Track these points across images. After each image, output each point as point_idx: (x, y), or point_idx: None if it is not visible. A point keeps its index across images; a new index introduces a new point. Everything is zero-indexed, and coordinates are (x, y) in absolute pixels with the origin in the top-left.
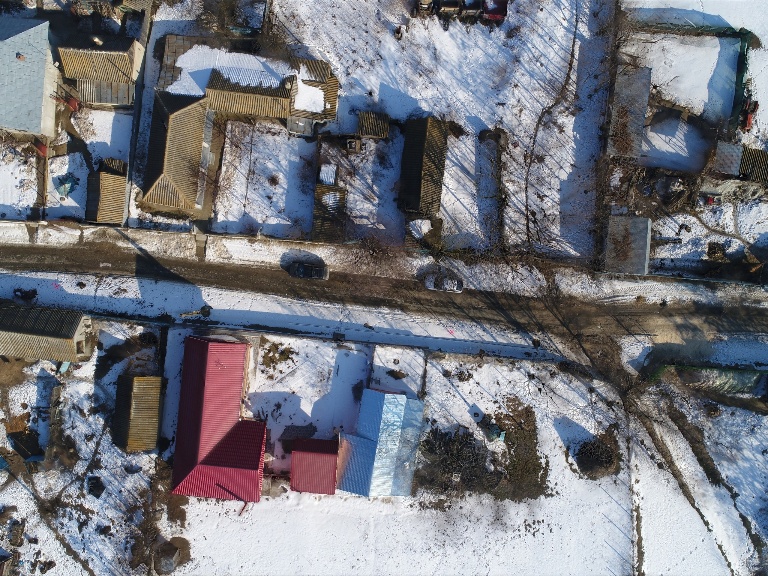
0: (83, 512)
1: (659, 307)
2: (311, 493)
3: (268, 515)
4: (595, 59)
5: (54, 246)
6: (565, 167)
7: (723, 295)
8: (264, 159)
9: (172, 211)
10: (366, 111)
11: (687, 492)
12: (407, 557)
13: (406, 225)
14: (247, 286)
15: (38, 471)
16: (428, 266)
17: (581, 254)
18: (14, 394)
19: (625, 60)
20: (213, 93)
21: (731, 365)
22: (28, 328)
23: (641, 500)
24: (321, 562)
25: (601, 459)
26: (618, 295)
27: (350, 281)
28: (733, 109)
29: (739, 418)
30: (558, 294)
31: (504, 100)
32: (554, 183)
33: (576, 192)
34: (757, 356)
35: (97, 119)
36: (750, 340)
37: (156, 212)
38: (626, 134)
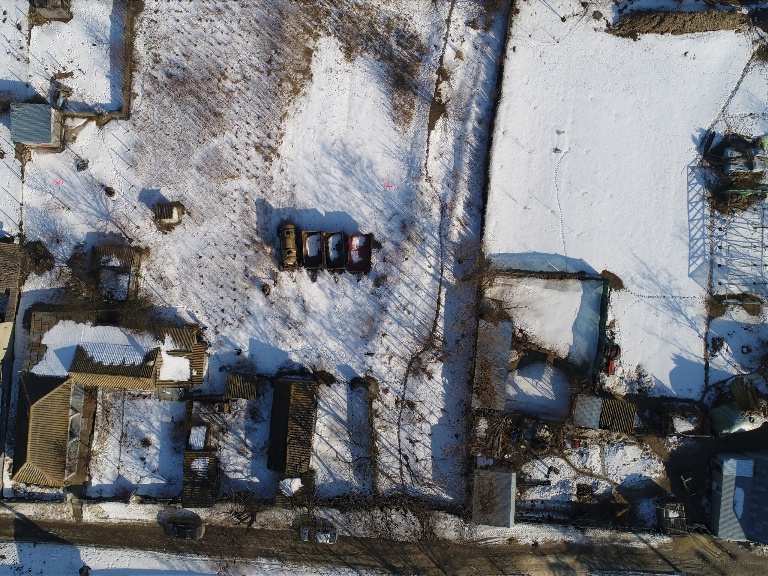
0: None
1: (531, 547)
2: None
3: None
4: (461, 305)
5: None
6: (435, 412)
7: (592, 536)
8: (136, 422)
9: None
10: (233, 374)
11: None
12: None
13: (276, 485)
14: (125, 543)
15: None
16: (303, 516)
17: (453, 498)
18: None
19: (491, 305)
20: (76, 375)
21: None
22: None
23: None
24: None
25: None
26: (491, 537)
27: (227, 533)
28: (597, 352)
29: None
30: (432, 538)
31: (372, 350)
32: (425, 428)
33: (447, 436)
34: None
35: None
36: None
37: None
38: (490, 387)
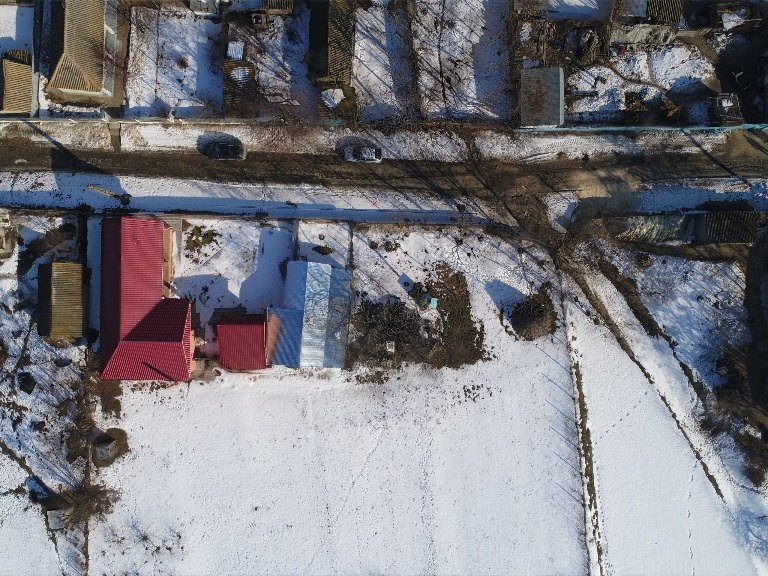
0: (16, 409)
1: (581, 162)
2: (245, 374)
3: (204, 400)
4: None
5: None
6: (476, 30)
7: (644, 143)
8: (172, 42)
9: (83, 100)
10: None
11: (625, 345)
12: (348, 432)
13: (318, 95)
14: (166, 173)
15: None
16: (346, 139)
17: (499, 115)
18: None
19: None
20: None
21: (657, 212)
22: None
23: (580, 357)
24: (261, 443)
25: (533, 314)
26: (539, 153)
27: (269, 160)
28: None
29: (671, 266)
30: (479, 157)
31: None
32: (466, 47)
33: (489, 54)
34: (683, 201)
35: (0, 14)
36: (675, 186)
37: (66, 102)
38: None
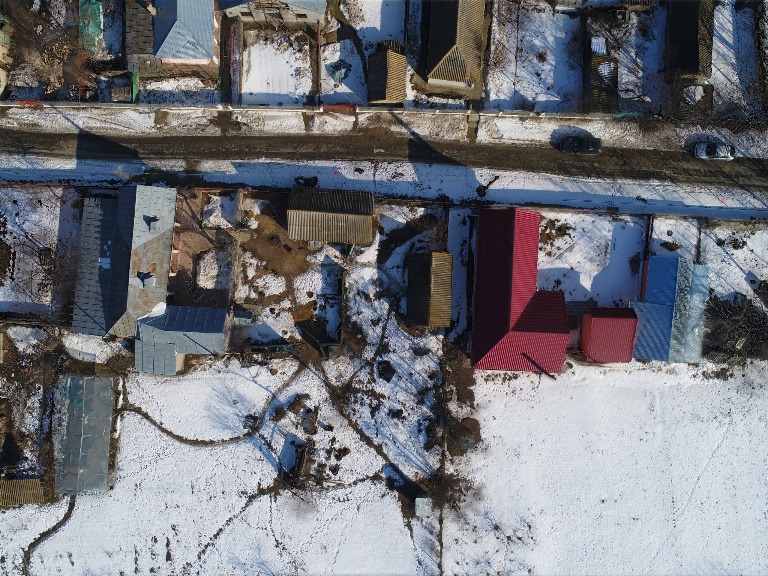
0: (374, 397)
1: None
2: (596, 367)
3: (554, 392)
4: None
5: (329, 134)
6: None
7: None
8: (531, 36)
9: (445, 92)
10: None
11: None
12: (694, 427)
13: (680, 92)
14: (518, 165)
15: (328, 358)
16: (696, 136)
17: None
18: (299, 283)
19: None
20: None
21: None
22: (327, 207)
23: None
24: (609, 436)
25: None
26: None
27: (619, 155)
28: None
29: None
30: None
31: None
32: None
33: None
34: None
35: (366, 5)
36: None
37: (430, 94)
38: None
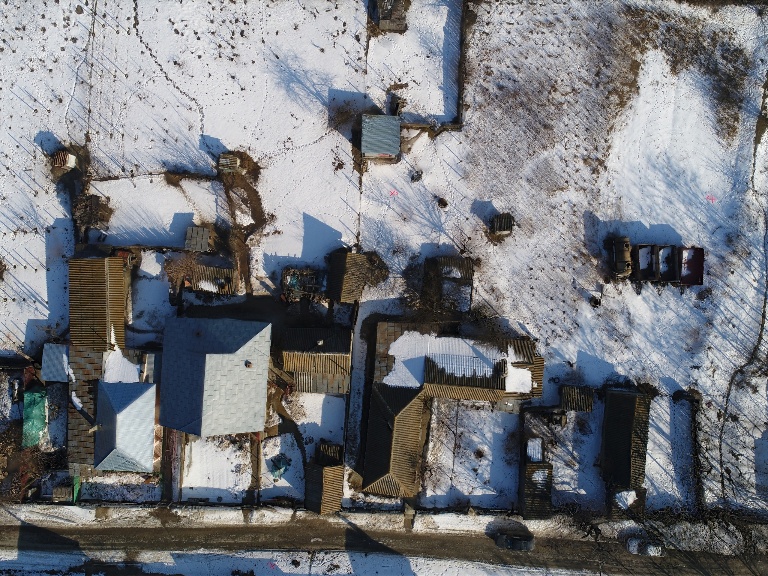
0: None
1: None
2: None
3: None
4: None
5: (267, 525)
6: (759, 426)
7: None
8: (469, 433)
9: None
10: (570, 386)
11: None
12: None
13: (612, 497)
14: (453, 554)
15: None
16: (629, 529)
17: None
18: None
19: None
20: (430, 386)
21: None
22: None
23: None
24: None
25: None
26: None
27: (553, 545)
28: None
29: None
30: (756, 552)
31: (699, 363)
32: (748, 442)
33: None
34: None
35: (307, 401)
36: None
37: None
38: None
